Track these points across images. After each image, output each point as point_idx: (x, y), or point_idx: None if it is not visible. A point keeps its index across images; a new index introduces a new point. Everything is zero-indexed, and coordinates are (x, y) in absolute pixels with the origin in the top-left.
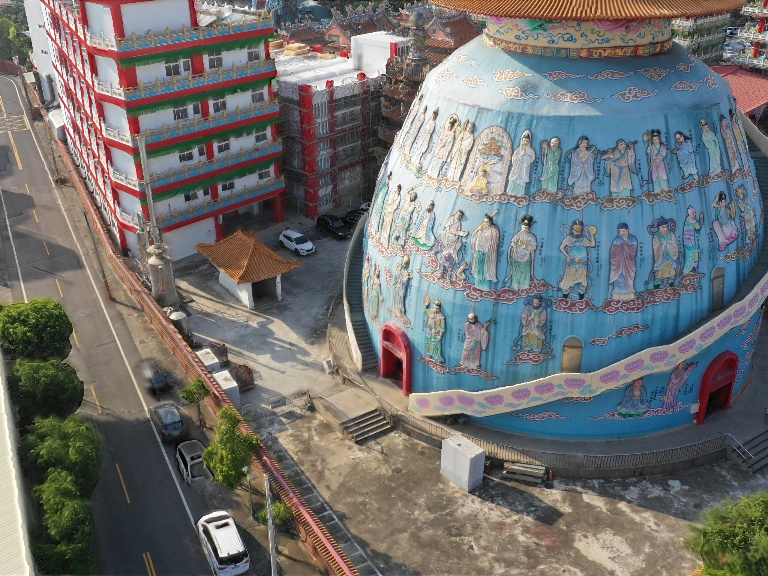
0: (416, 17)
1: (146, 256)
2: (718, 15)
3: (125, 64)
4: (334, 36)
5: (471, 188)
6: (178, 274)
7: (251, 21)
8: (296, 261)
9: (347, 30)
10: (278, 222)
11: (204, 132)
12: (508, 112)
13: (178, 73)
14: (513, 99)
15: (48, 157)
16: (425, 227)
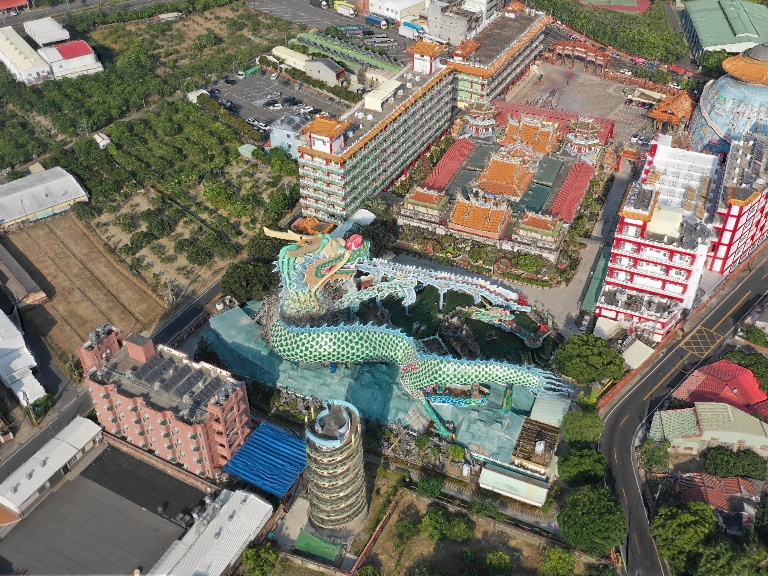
0: None
1: None
2: None
3: None
4: None
5: None
6: None
7: (752, 134)
8: None
9: None
10: None
11: None
12: None
13: None
14: None
15: (728, 293)
16: None
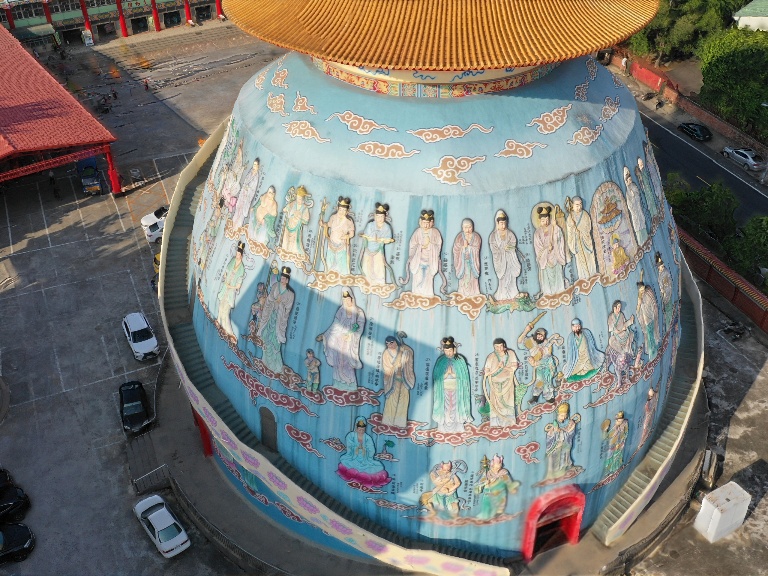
0: None
1: None
2: None
3: None
4: None
5: (616, 269)
6: None
7: None
8: None
9: None
10: None
11: None
12: (606, 160)
13: None
14: (594, 143)
15: None
16: (587, 353)
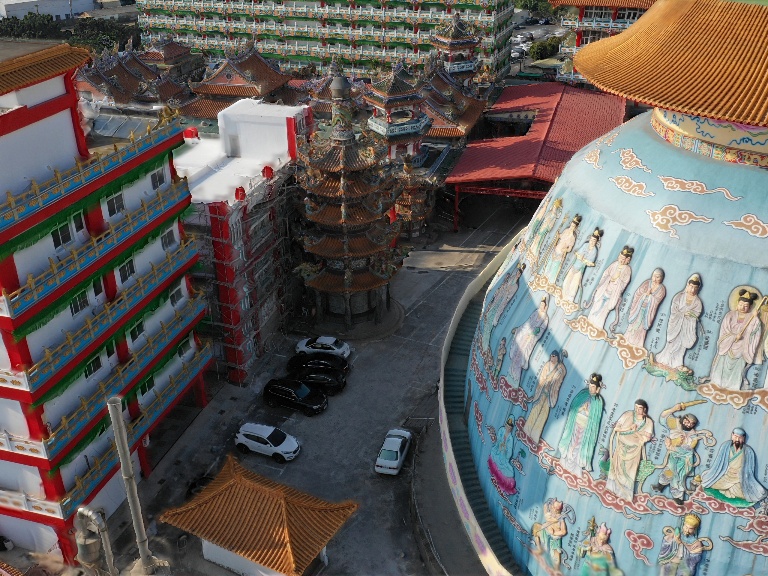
0: (342, 84)
1: (98, 574)
2: (506, 27)
3: (2, 254)
4: (81, 92)
5: None
6: (119, 560)
7: (154, 128)
8: (284, 473)
9: (98, 83)
10: (203, 406)
11: (120, 322)
12: None
13: (68, 238)
14: None
15: None
16: (738, 473)
